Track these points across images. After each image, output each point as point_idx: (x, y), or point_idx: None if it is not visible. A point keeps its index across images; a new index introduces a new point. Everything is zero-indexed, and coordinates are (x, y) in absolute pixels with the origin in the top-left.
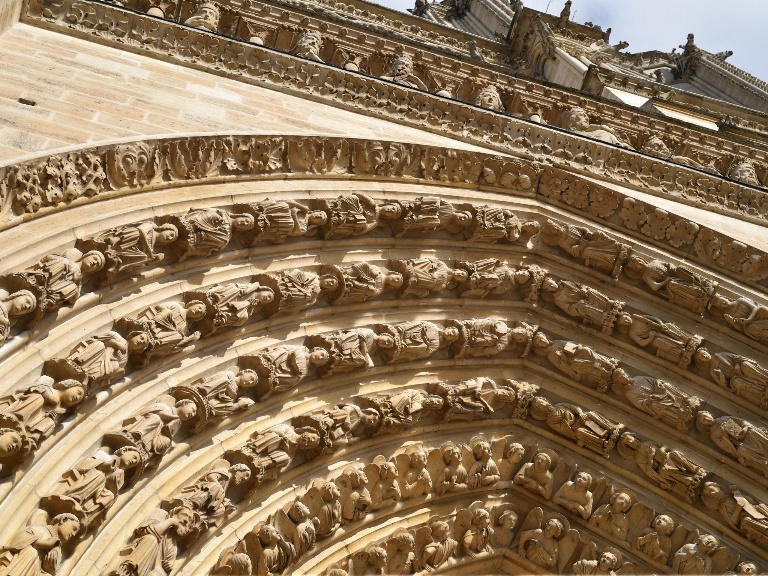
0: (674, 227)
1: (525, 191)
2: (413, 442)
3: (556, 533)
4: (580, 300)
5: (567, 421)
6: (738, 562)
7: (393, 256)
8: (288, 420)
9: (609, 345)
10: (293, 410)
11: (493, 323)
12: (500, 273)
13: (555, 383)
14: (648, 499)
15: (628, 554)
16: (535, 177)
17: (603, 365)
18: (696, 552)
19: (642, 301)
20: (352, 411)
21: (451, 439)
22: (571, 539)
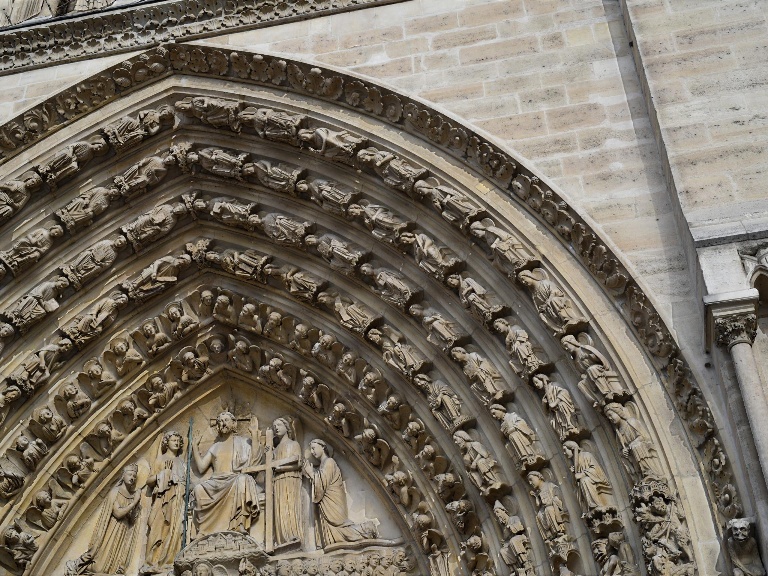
0: (271, 68)
1: (162, 74)
2: (119, 333)
3: (242, 352)
4: (213, 167)
5: (229, 267)
6: (343, 353)
7: (56, 207)
8: (2, 383)
9: (250, 189)
10: (4, 373)
11: (151, 218)
12: (149, 170)
13: (223, 232)
14: (294, 310)
15: (292, 352)
16: (164, 60)
17: (240, 216)
18: (319, 350)
19: (261, 146)
20: (47, 353)
21: (152, 313)
22: (255, 351)
